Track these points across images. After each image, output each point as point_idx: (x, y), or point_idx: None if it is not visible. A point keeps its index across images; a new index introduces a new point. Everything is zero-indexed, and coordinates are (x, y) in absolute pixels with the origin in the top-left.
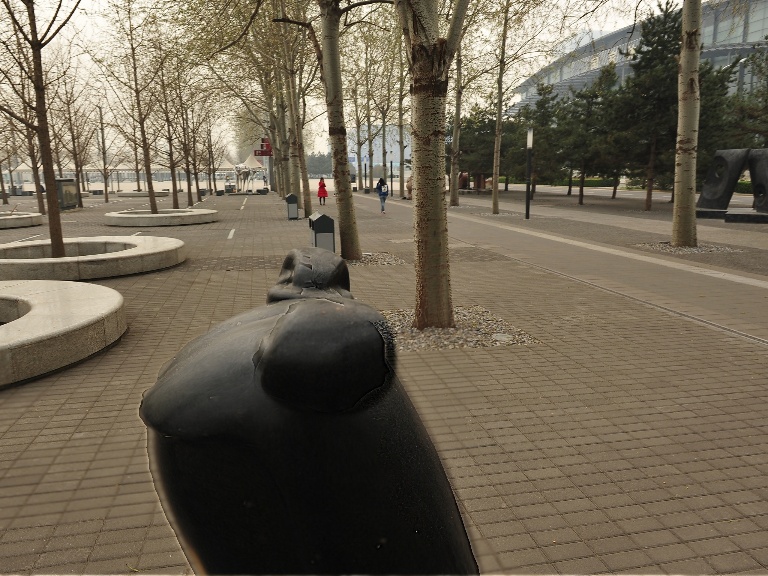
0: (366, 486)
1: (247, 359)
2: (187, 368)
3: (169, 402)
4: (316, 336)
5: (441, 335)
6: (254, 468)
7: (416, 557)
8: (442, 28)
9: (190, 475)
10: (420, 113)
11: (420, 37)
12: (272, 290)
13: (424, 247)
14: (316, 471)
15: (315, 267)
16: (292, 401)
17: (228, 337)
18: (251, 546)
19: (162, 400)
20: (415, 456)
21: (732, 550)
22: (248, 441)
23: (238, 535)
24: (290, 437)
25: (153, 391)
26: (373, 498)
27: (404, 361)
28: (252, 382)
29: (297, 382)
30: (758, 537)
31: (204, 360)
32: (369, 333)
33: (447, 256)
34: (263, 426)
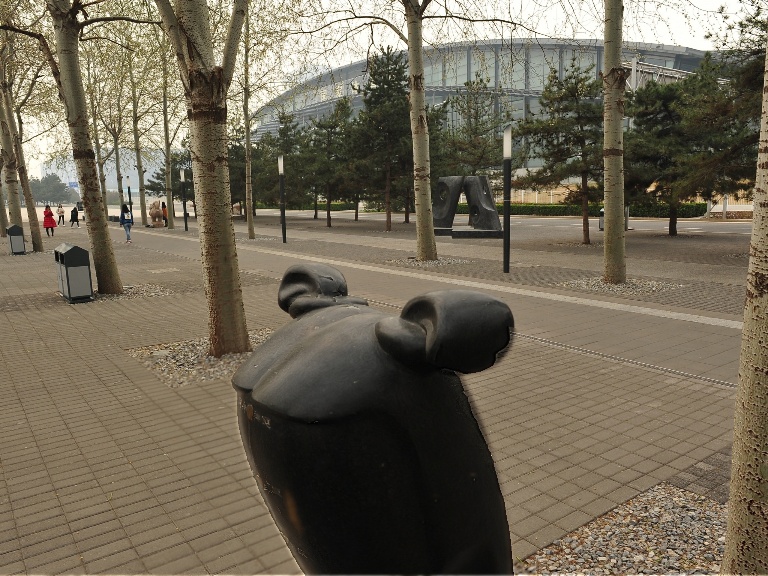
0: (463, 435)
1: (364, 350)
2: (301, 367)
3: (312, 393)
4: (464, 317)
5: (241, 360)
6: (394, 433)
7: (490, 485)
8: (217, 56)
9: (336, 452)
10: (202, 139)
11: (197, 63)
12: (301, 302)
13: (215, 273)
14: (434, 428)
15: (334, 279)
16: (451, 368)
17: (325, 337)
18: (387, 500)
19: (302, 393)
20: (469, 413)
21: (536, 495)
22: (391, 411)
23: (376, 494)
24: (413, 405)
25: (275, 391)
26: (468, 443)
27: (211, 390)
28: (379, 366)
29: (459, 352)
30: (550, 481)
31: (319, 357)
32: (498, 311)
33: (239, 281)
34: (396, 399)
